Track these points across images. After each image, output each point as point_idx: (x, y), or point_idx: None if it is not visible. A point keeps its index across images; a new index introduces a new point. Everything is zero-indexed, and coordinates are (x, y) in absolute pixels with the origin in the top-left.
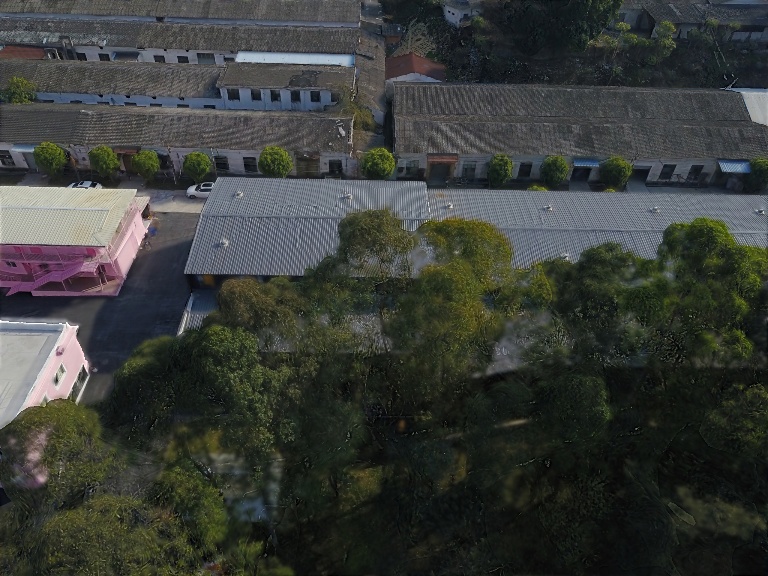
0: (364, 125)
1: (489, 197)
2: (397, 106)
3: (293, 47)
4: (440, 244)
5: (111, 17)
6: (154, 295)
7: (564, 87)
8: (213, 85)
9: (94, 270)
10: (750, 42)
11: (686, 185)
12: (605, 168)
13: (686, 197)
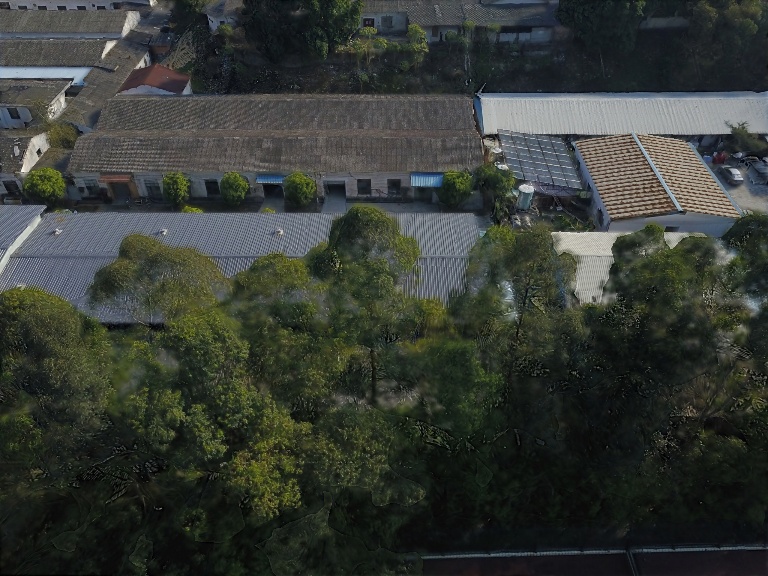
0: (64, 142)
1: (110, 221)
2: (101, 121)
3: (32, 61)
4: None
5: None
6: None
7: (291, 97)
8: None
9: None
10: (510, 44)
11: (390, 200)
12: (285, 184)
13: (327, 217)
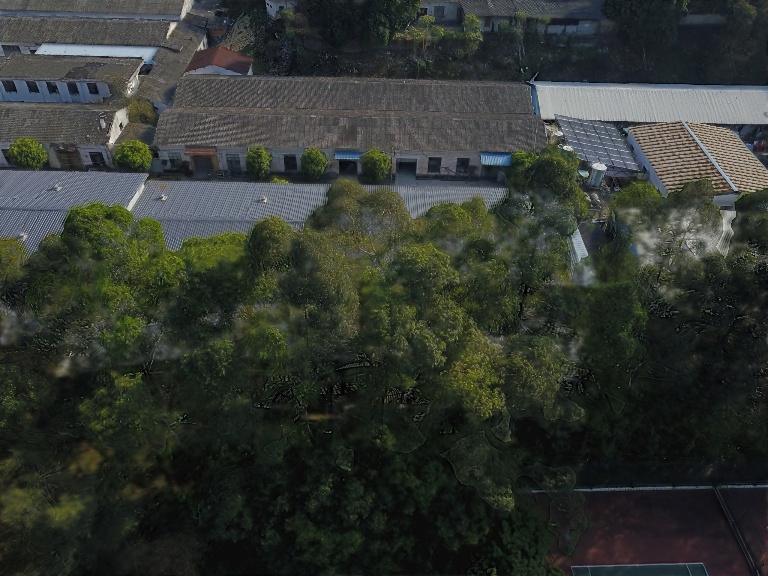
0: (142, 117)
1: (210, 189)
2: (177, 98)
3: (98, 39)
4: None
5: None
6: None
7: (356, 80)
8: None
9: None
10: (560, 35)
11: (457, 178)
12: (363, 161)
13: (414, 189)
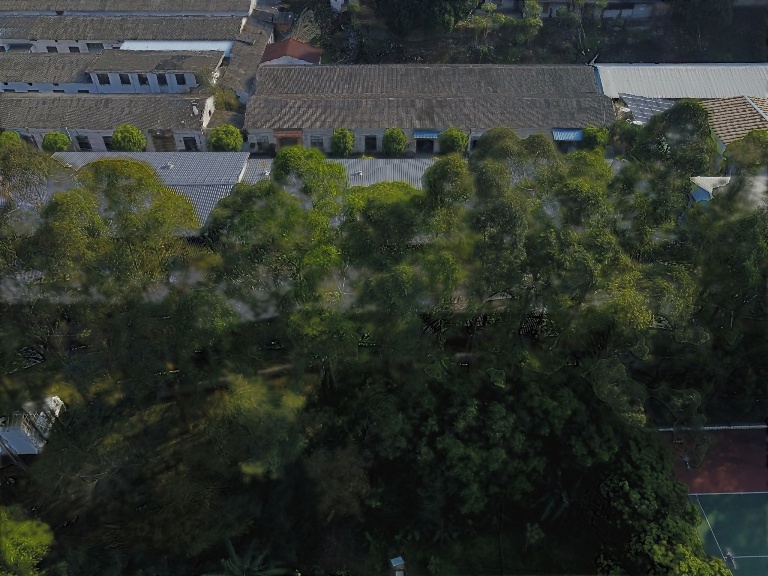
0: (226, 105)
1: None
2: (259, 87)
3: (177, 35)
4: (86, 179)
5: (14, 12)
6: None
7: (425, 65)
8: None
9: None
10: (617, 19)
11: None
12: (441, 139)
13: None
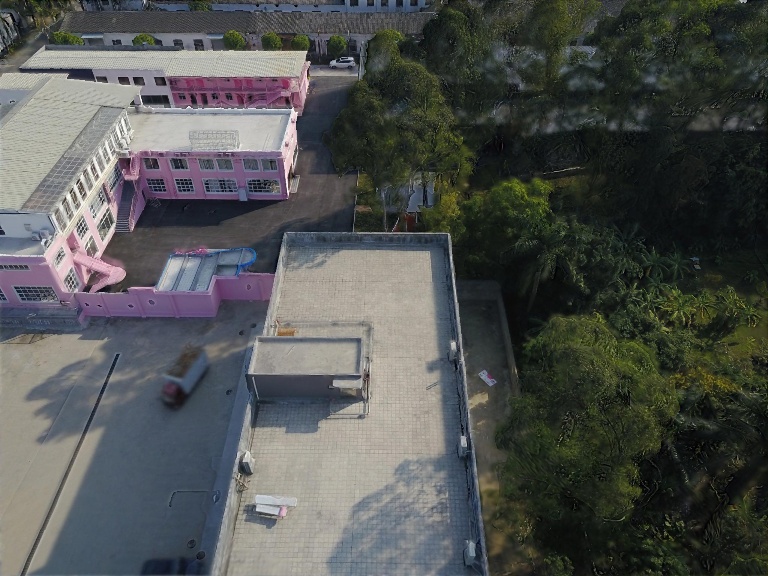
0: None
1: None
2: None
3: None
4: None
5: None
6: (325, 116)
7: None
8: None
9: (290, 95)
10: None
11: None
12: None
13: None
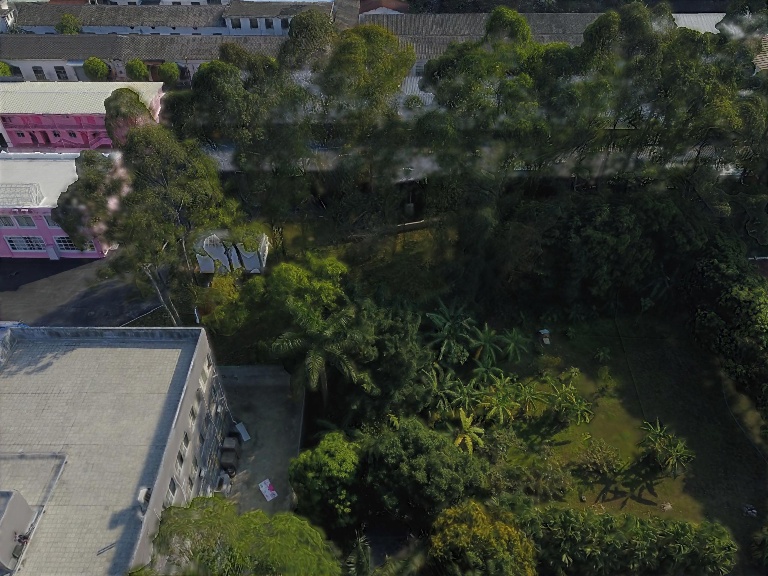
0: None
1: None
2: None
3: None
4: None
5: None
6: None
7: None
8: (220, 17)
9: None
10: None
11: None
12: None
13: None
